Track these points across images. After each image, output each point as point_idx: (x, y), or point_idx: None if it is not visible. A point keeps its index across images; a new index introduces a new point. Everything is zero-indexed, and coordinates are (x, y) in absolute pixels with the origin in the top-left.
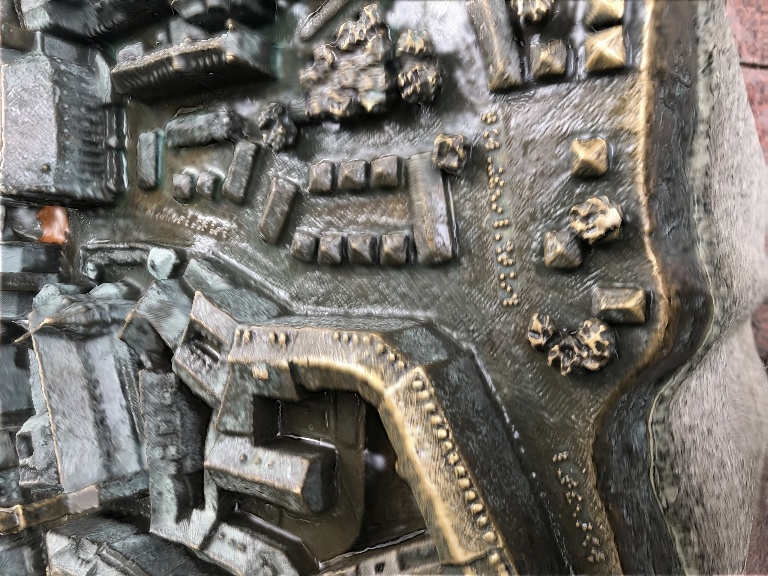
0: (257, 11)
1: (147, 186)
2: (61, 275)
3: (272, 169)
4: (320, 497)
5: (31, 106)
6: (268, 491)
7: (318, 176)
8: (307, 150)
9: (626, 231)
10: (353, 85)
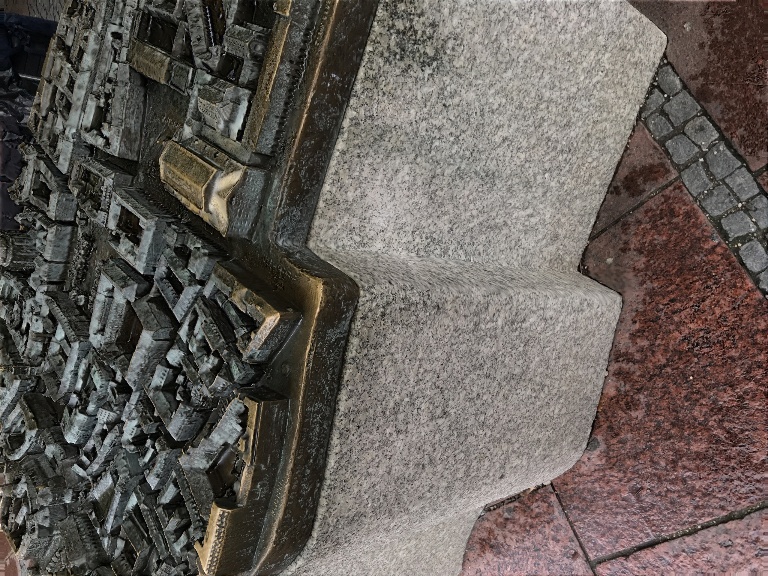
0: None
1: None
2: None
3: None
4: None
5: None
6: None
7: None
8: None
9: None
10: None
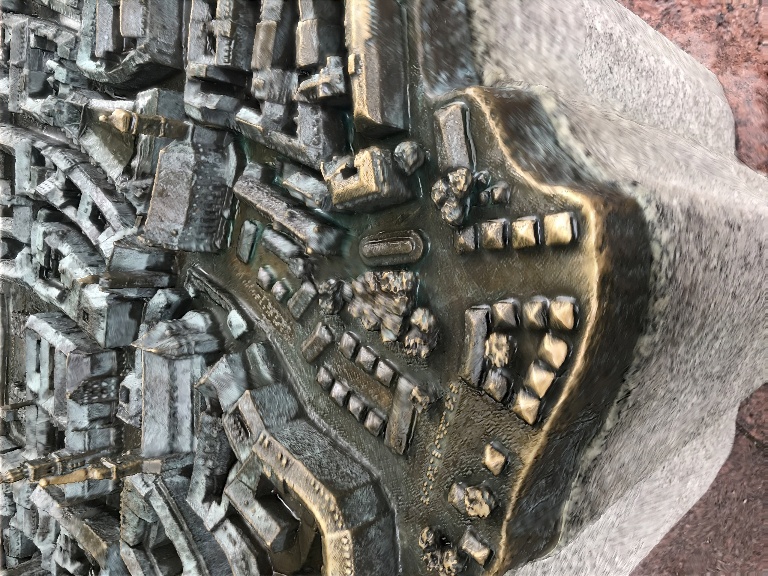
0: (341, 211)
1: (241, 260)
2: (171, 277)
3: (322, 311)
4: (282, 545)
5: (174, 185)
6: None
7: (345, 348)
8: (347, 317)
9: (497, 510)
10: (381, 316)
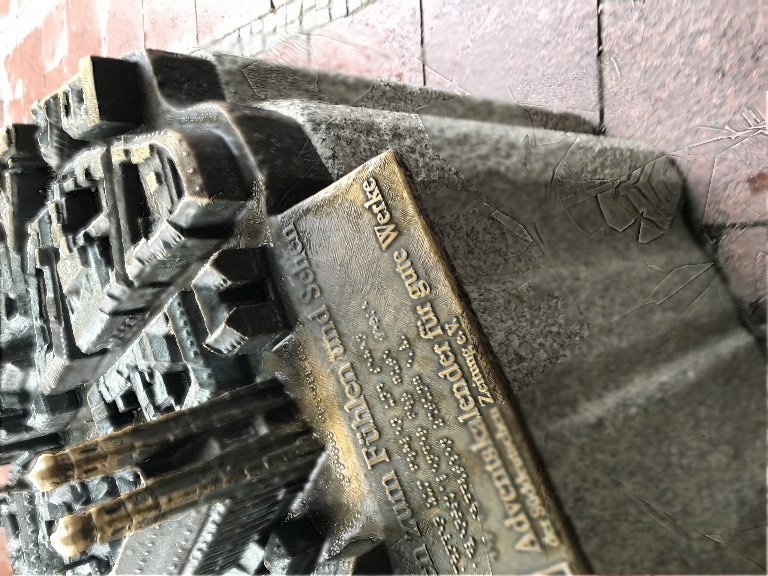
0: None
1: None
2: None
3: None
4: None
5: None
6: (2, 261)
7: None
8: None
9: None
10: None
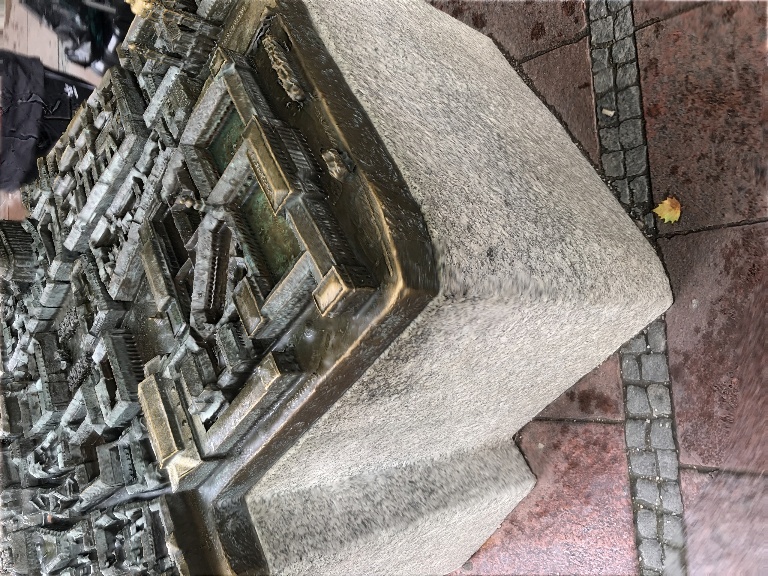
0: None
1: None
2: None
3: None
4: None
5: None
6: None
7: None
8: None
9: None
10: None
